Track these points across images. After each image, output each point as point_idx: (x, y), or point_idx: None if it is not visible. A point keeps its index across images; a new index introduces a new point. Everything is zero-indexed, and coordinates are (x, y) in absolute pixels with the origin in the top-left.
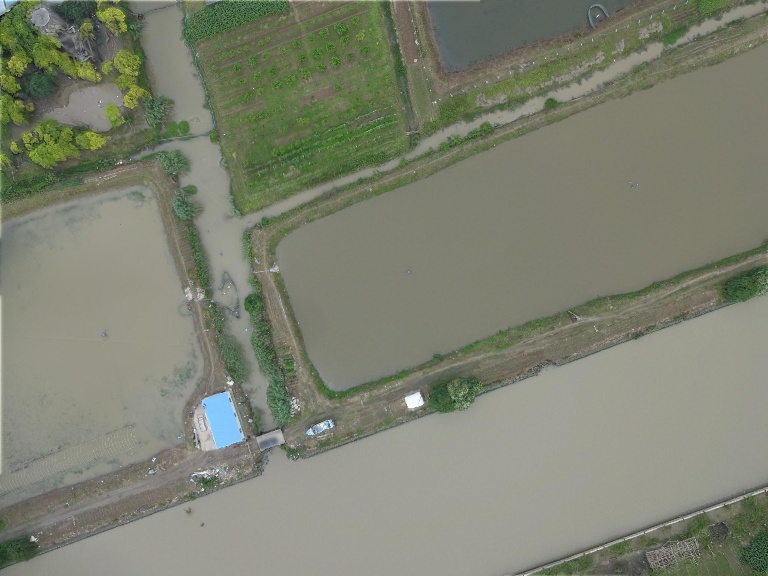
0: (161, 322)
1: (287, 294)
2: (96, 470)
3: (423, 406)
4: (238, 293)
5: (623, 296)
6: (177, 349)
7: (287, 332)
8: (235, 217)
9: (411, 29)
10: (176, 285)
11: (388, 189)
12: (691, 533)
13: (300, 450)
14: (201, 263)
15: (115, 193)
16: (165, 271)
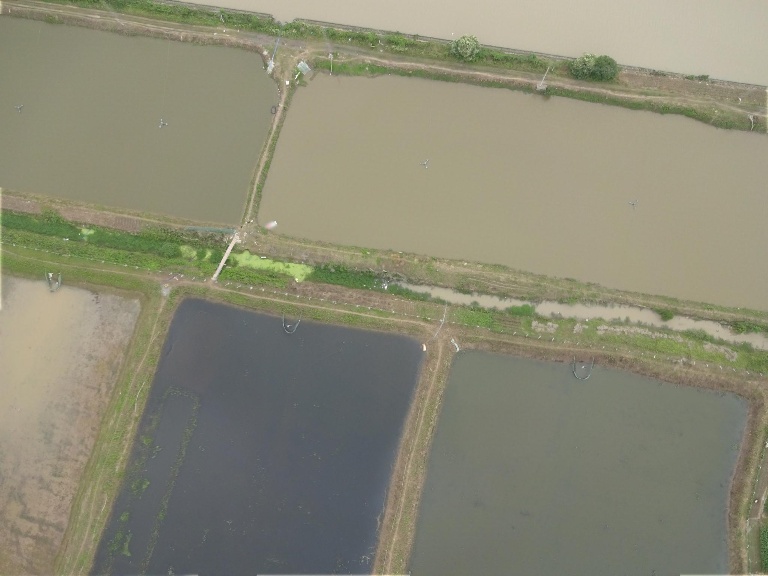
0: None
1: None
2: None
3: None
4: None
5: (699, 116)
6: None
7: None
8: None
9: (765, 461)
10: None
11: None
12: None
13: None
14: None
15: None
16: None
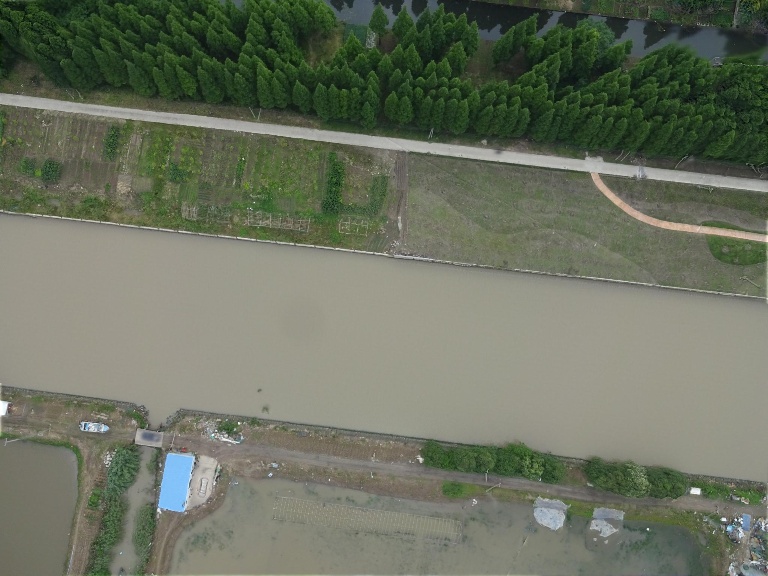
0: None
1: (64, 567)
2: (332, 493)
3: None
4: None
5: None
6: (194, 571)
7: (80, 532)
8: None
9: None
10: None
11: None
12: None
13: (130, 414)
14: None
15: None
16: None
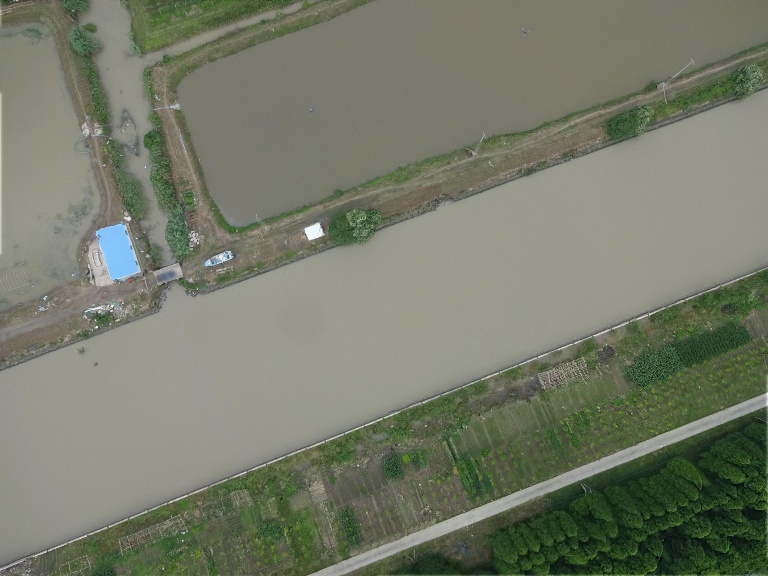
0: (56, 159)
1: (188, 132)
2: None
3: (323, 239)
4: (137, 130)
5: (516, 134)
6: (72, 186)
7: (187, 167)
8: (136, 56)
9: None
10: (73, 122)
11: (291, 31)
12: (580, 355)
13: (199, 284)
14: (99, 99)
15: (10, 30)
16: (61, 108)
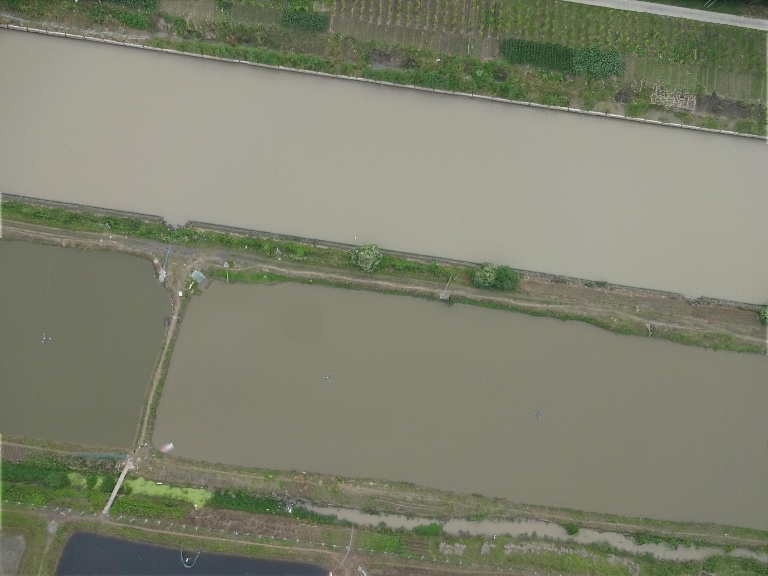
0: None
1: None
2: None
3: None
4: None
5: (599, 324)
6: None
7: None
8: None
9: None
10: None
11: (754, 532)
12: (648, 107)
13: None
14: None
15: None
16: None
